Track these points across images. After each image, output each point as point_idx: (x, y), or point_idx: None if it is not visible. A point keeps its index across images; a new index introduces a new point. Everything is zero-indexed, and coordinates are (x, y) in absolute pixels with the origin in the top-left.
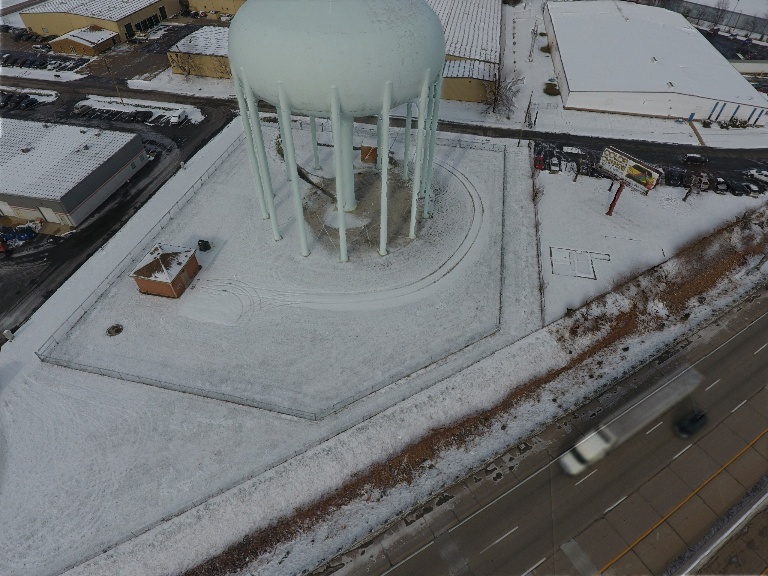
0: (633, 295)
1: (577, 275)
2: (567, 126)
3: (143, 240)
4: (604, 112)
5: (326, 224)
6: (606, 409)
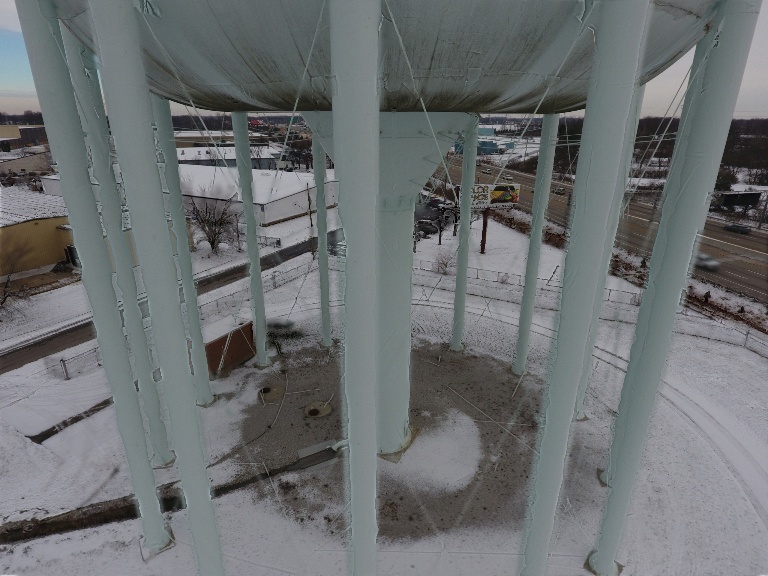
0: (620, 273)
1: None
2: (299, 234)
3: None
4: (296, 217)
5: (457, 489)
6: None
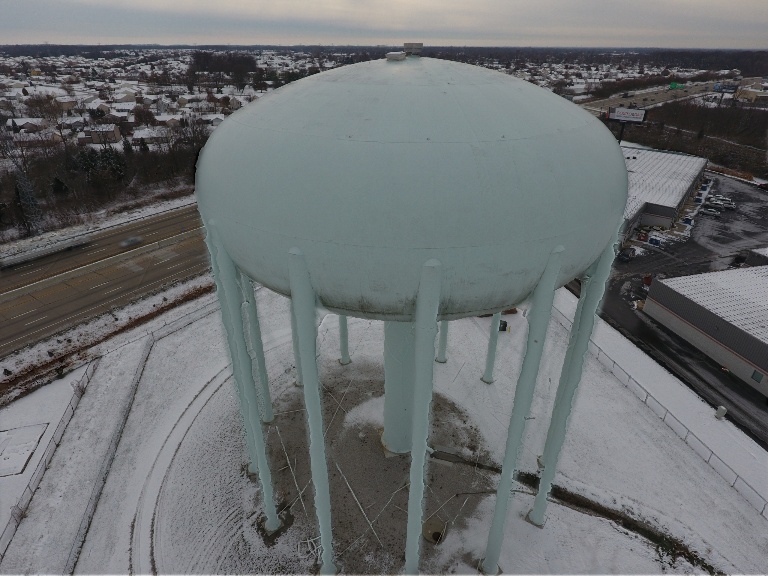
0: None
1: (8, 431)
2: None
3: (565, 318)
4: None
5: None
6: (72, 322)
